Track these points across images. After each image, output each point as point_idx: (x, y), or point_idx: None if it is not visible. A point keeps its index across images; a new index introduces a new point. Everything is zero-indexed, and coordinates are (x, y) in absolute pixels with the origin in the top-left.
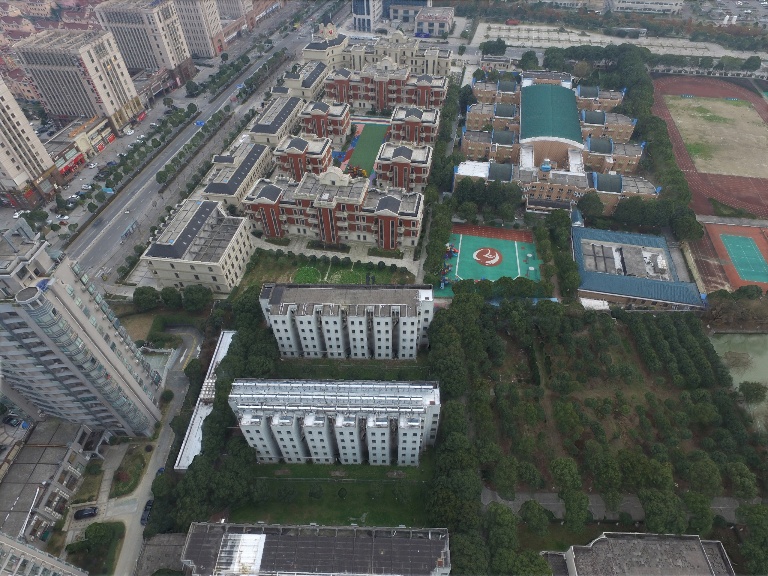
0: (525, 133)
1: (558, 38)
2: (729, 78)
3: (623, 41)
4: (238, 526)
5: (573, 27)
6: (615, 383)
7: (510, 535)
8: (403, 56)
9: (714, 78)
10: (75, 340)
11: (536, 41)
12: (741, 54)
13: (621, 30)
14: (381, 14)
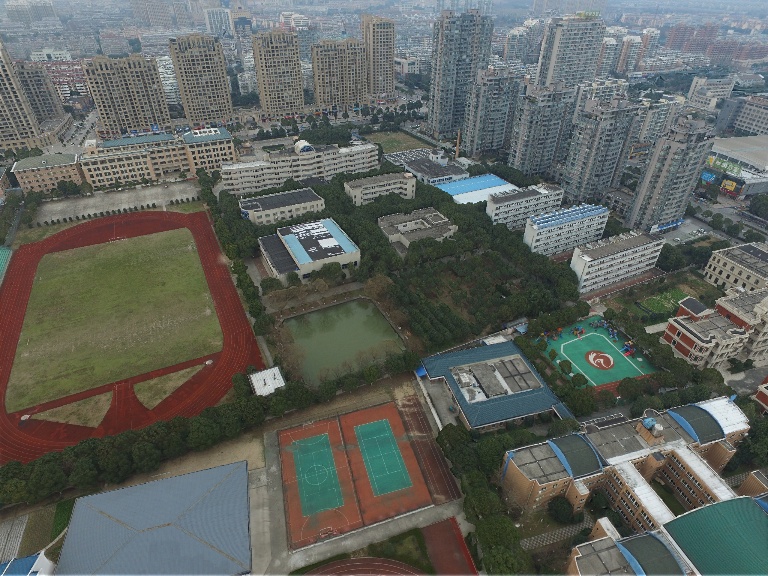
0: (767, 519)
1: None
2: None
3: None
4: (552, 193)
5: None
6: (458, 304)
7: None
8: None
9: None
10: (648, 159)
11: None
12: None
13: None
14: None
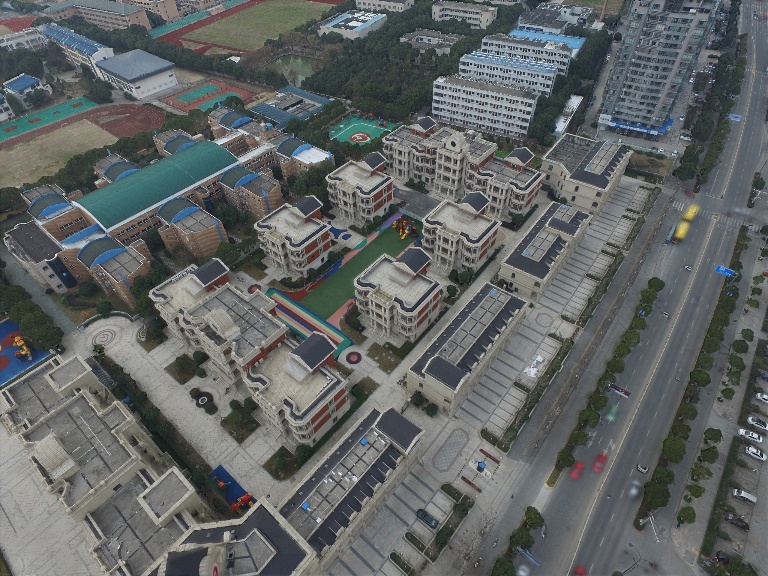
0: (224, 163)
1: None
2: None
3: None
4: None
5: None
6: None
7: (459, 50)
8: None
9: None
10: None
11: None
12: None
13: None
14: None
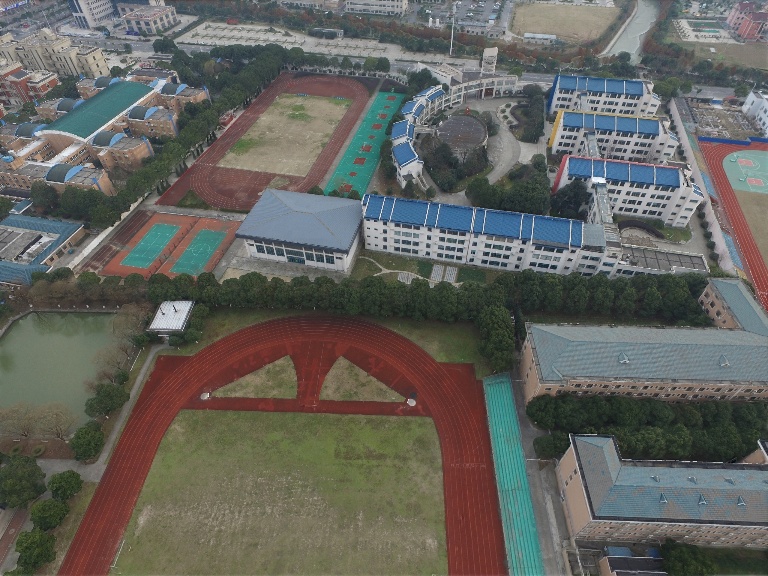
0: (46, 126)
1: (259, 38)
2: (361, 78)
3: (315, 41)
4: None
5: (286, 27)
6: None
7: None
8: (45, 53)
9: (350, 78)
10: None
11: (234, 40)
12: (409, 55)
13: (319, 31)
14: (113, 12)
